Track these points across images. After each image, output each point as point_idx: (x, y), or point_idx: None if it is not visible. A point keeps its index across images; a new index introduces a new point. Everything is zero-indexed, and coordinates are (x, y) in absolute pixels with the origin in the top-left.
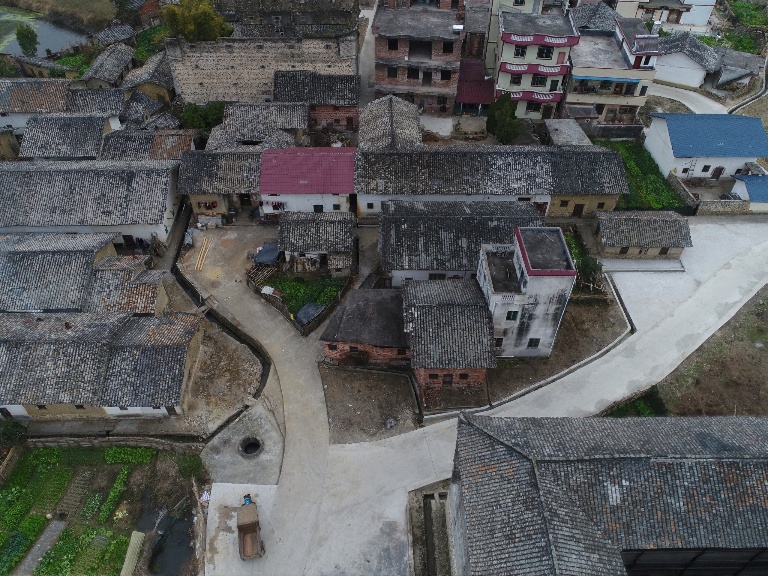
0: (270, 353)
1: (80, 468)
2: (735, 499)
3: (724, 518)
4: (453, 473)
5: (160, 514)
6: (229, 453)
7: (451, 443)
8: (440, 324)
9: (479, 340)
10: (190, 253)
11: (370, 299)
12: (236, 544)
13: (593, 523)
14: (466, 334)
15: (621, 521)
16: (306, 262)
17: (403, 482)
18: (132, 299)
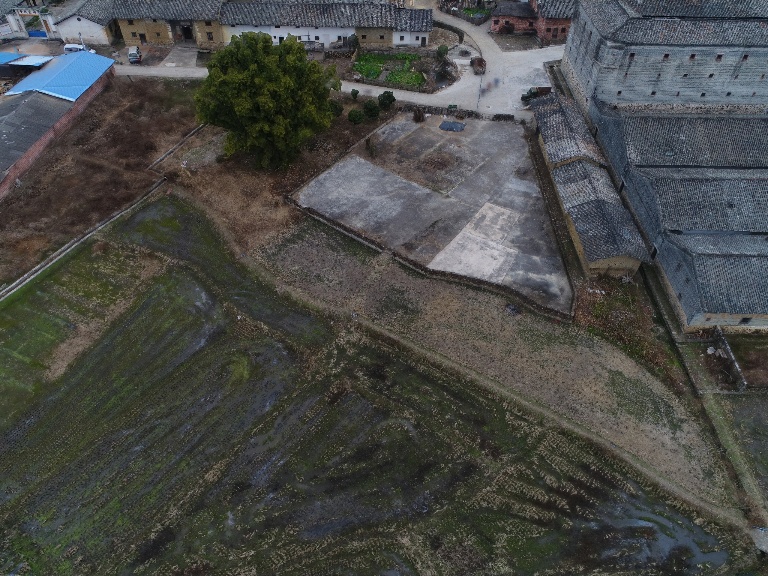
0: (463, 30)
1: (386, 60)
2: (685, 3)
3: (681, 8)
4: (574, 12)
5: (433, 65)
6: (455, 56)
7: (560, 51)
8: (553, 1)
9: (572, 7)
10: (405, 0)
11: (513, 4)
12: (471, 72)
13: (632, 8)
14: (566, 5)
15: (642, 8)
16: (470, 2)
17: (540, 60)
18: (393, 2)
